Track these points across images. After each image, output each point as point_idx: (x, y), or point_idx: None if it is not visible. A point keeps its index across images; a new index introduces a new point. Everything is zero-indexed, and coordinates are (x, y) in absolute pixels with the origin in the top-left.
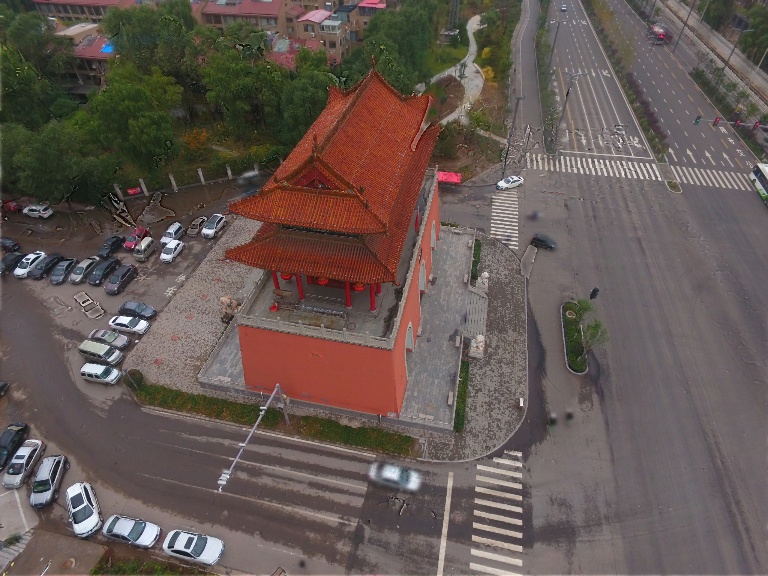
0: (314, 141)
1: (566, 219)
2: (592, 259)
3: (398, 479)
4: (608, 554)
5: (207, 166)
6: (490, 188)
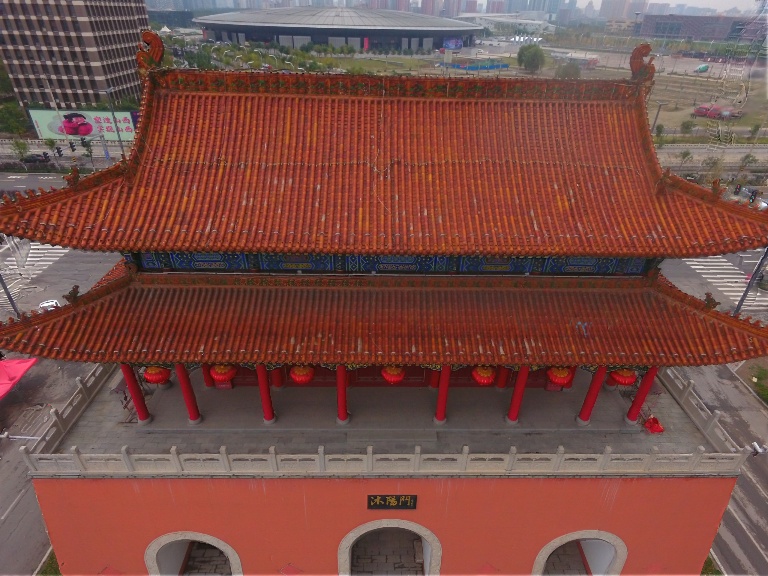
0: None
1: None
2: None
3: None
4: None
5: None
6: None
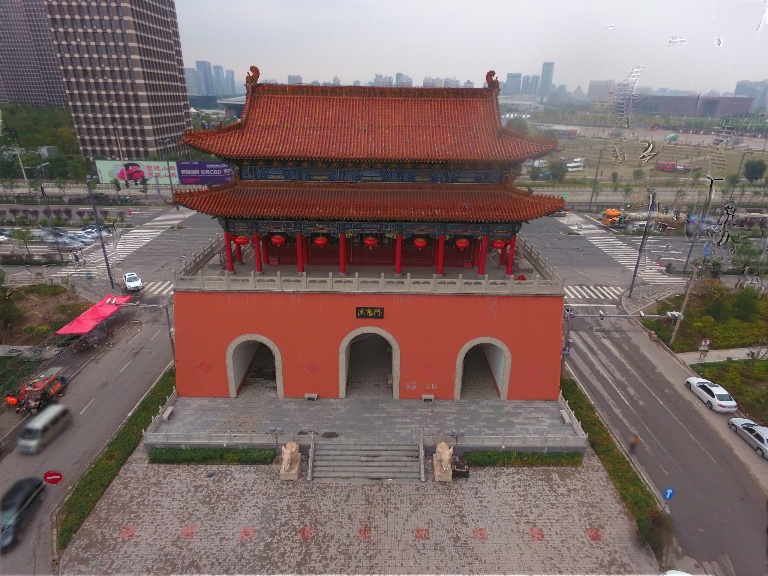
0: None
1: None
2: None
3: None
4: None
5: None
6: None
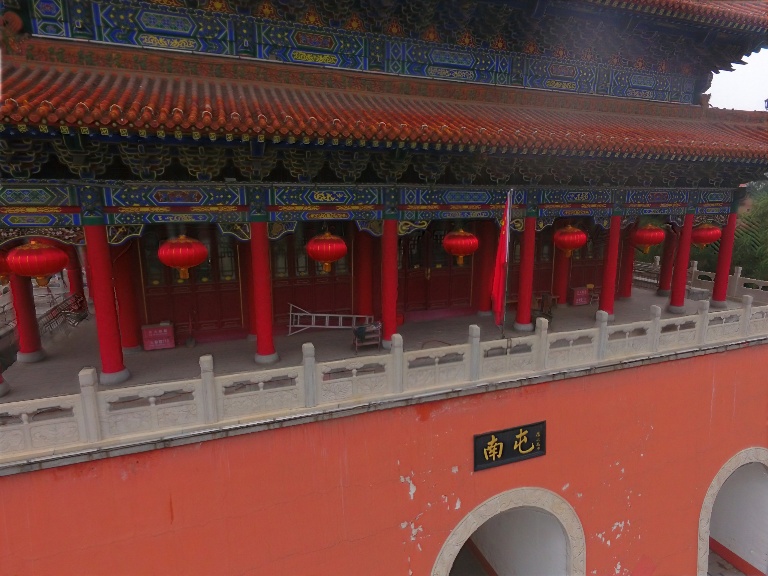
0: None
1: None
2: None
3: None
4: None
5: None
6: None
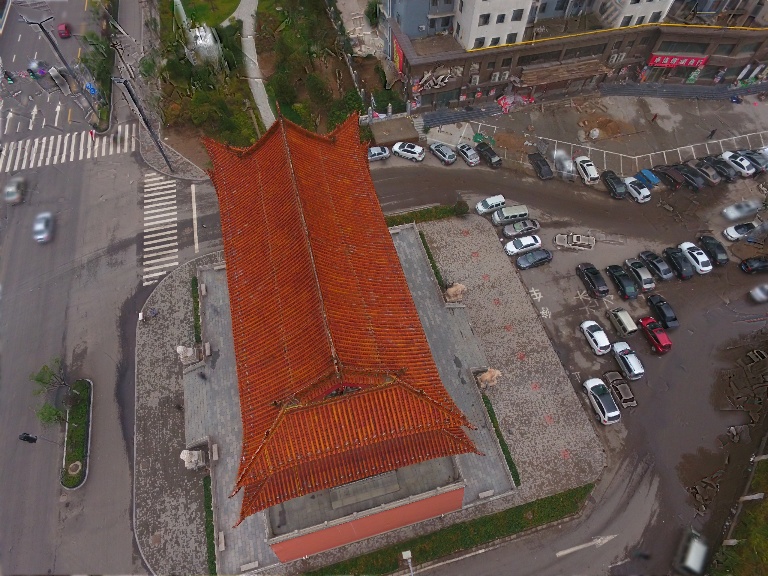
0: None
1: None
2: None
3: None
4: (87, 248)
5: (761, 510)
6: None
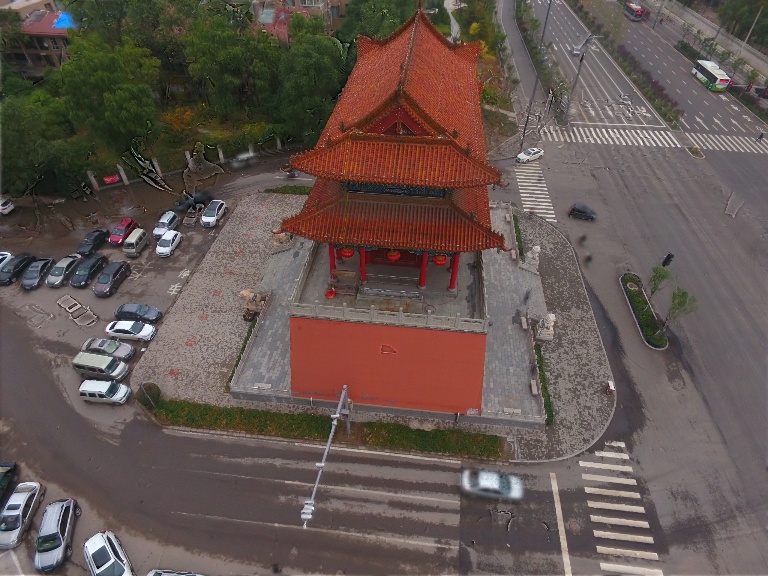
0: (401, 70)
1: (597, 189)
2: (636, 228)
3: (494, 487)
4: (754, 551)
5: None
6: (509, 162)
